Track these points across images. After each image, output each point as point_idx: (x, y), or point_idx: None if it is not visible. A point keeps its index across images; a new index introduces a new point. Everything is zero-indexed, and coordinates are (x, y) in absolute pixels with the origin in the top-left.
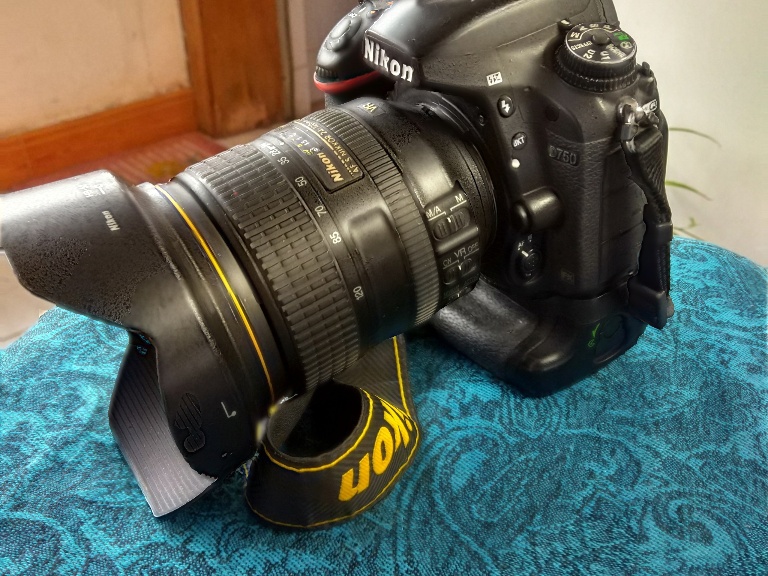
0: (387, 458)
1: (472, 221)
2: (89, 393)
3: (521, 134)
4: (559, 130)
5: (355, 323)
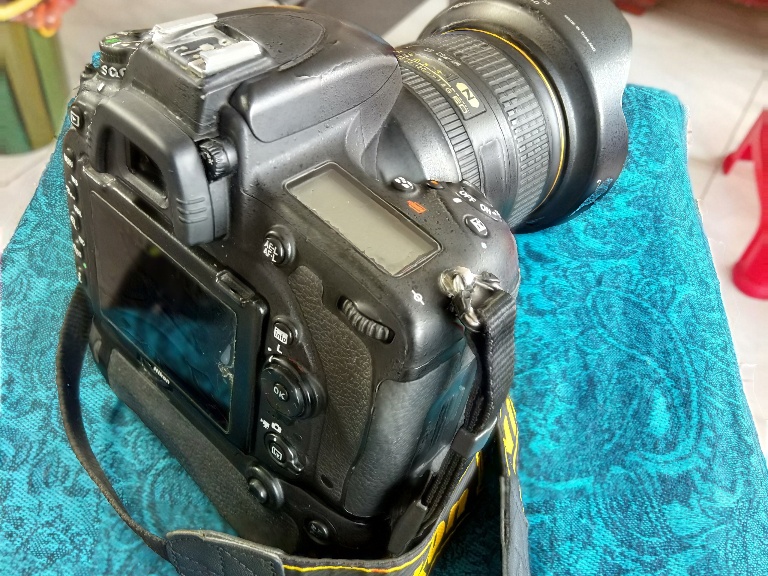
0: None
1: None
2: (589, 242)
3: None
4: None
5: None
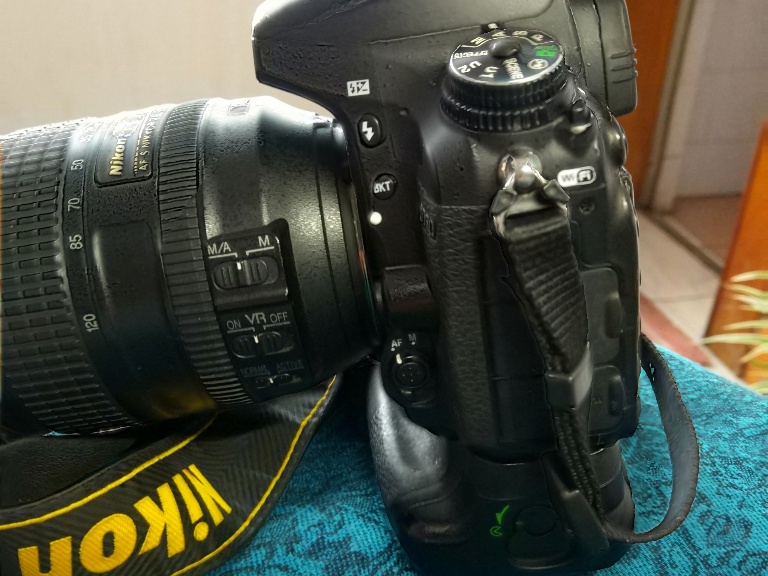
0: (117, 557)
1: (280, 279)
2: None
3: (389, 177)
4: (427, 180)
5: (88, 361)
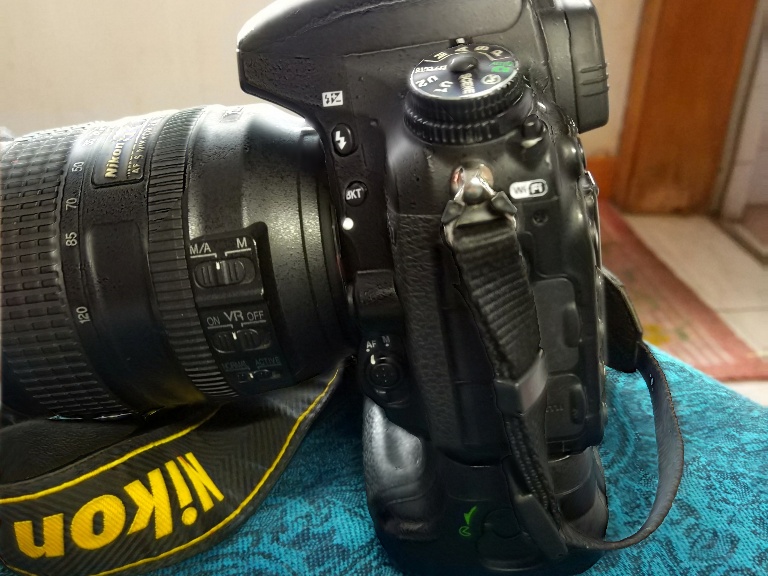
0: (107, 535)
1: (257, 279)
2: None
3: (360, 185)
4: None
5: (81, 351)
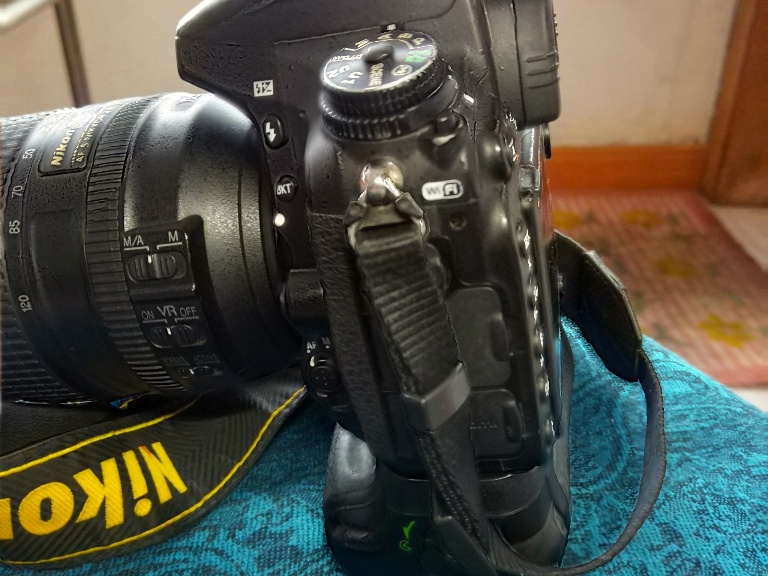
0: (55, 522)
1: (188, 274)
2: None
3: (291, 179)
4: None
5: (26, 339)
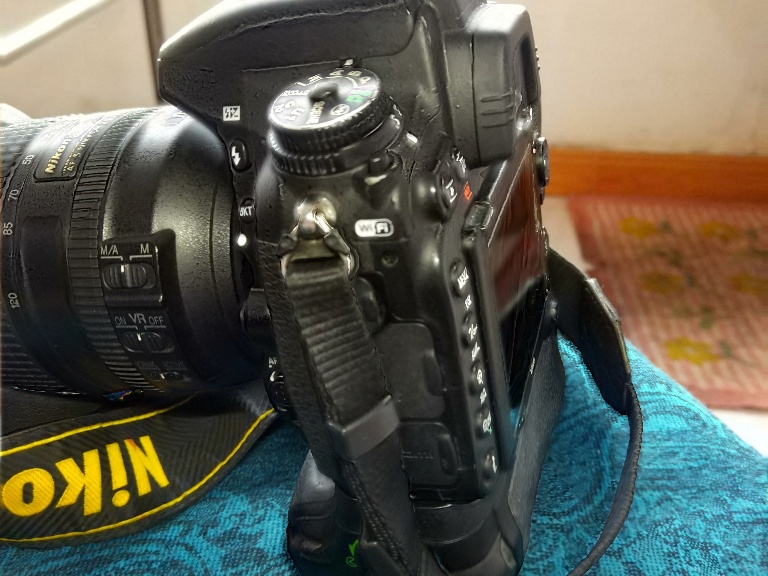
0: (36, 505)
1: (157, 285)
2: None
3: (252, 202)
4: None
5: (15, 333)
